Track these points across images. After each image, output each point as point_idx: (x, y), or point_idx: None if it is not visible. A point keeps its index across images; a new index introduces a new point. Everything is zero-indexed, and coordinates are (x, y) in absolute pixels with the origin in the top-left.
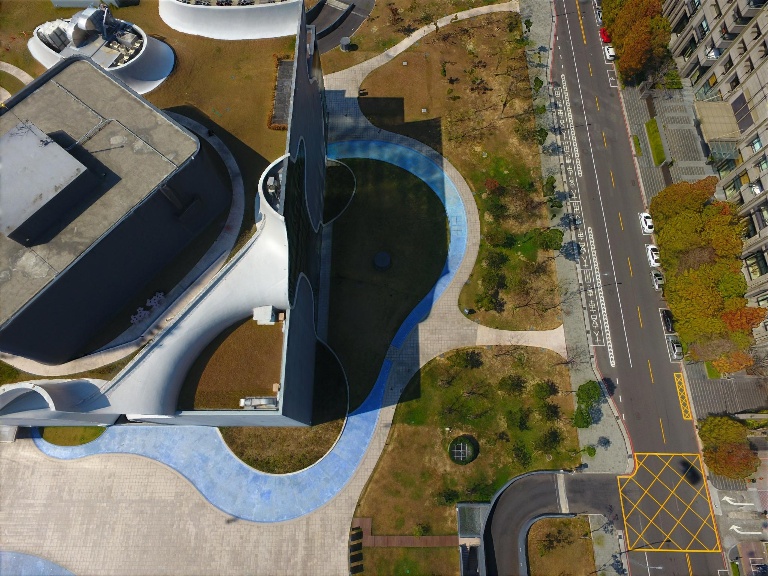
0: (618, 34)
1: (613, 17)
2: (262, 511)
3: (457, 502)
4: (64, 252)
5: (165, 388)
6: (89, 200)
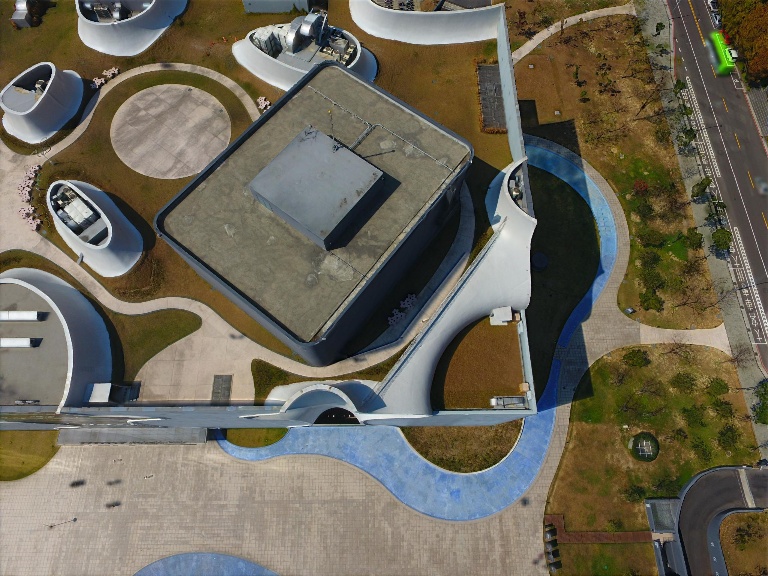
0: (748, 37)
1: (740, 20)
2: (454, 509)
3: (645, 498)
4: (364, 255)
5: (427, 388)
6: (375, 204)
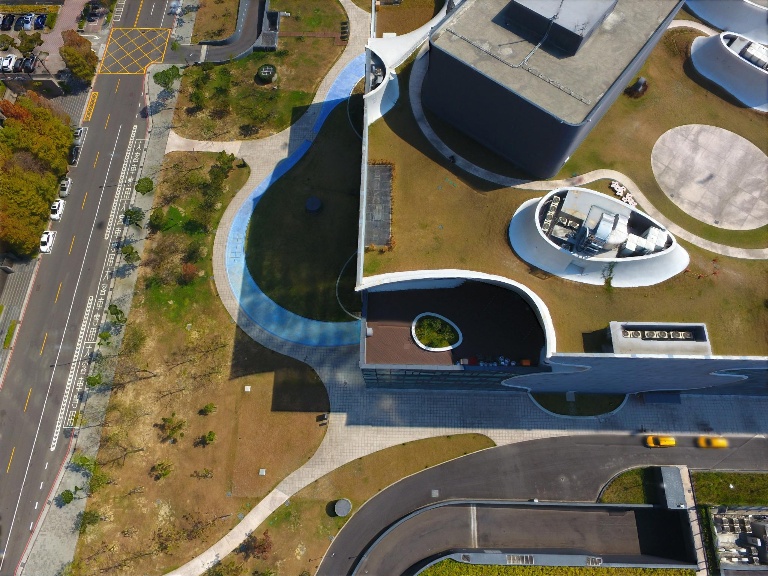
0: None
1: None
2: None
3: None
4: None
5: None
6: None
